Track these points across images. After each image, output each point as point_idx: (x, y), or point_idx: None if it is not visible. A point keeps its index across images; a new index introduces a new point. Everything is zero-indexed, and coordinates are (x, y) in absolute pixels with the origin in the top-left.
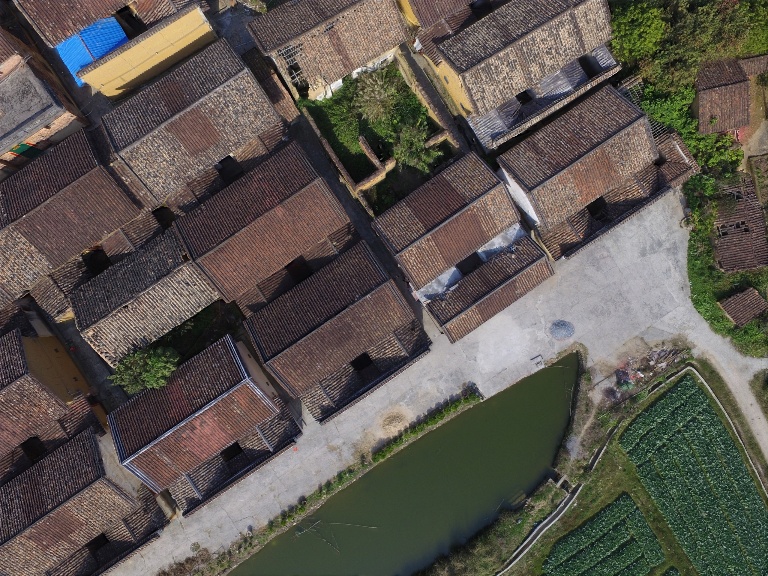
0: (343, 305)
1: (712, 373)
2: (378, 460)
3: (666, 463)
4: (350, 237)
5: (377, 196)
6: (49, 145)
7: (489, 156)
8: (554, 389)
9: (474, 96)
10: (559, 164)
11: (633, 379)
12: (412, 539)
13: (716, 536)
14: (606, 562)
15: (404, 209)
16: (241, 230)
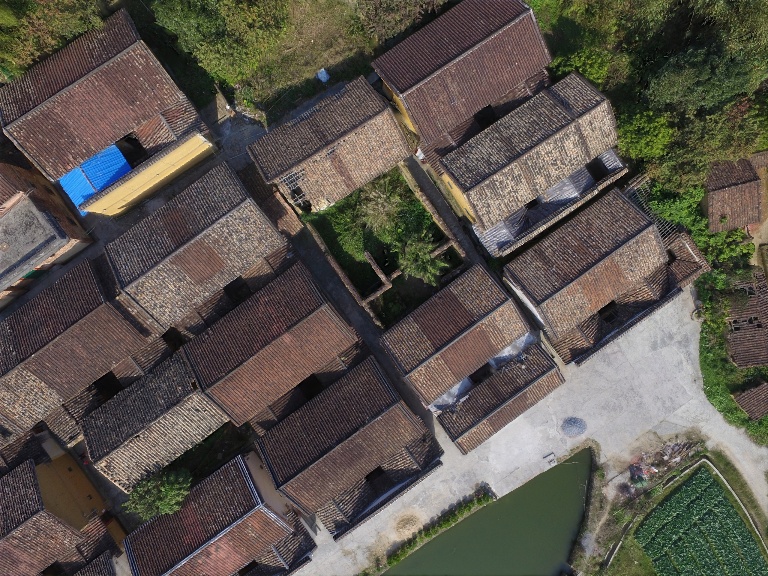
0: (354, 427)
1: (727, 465)
2: (393, 564)
3: (682, 557)
4: (358, 351)
5: (384, 301)
6: (54, 264)
7: (495, 258)
8: (567, 485)
9: (479, 211)
10: (567, 275)
11: (647, 474)
12: None
13: None
14: None
15: (412, 325)
16: (249, 359)
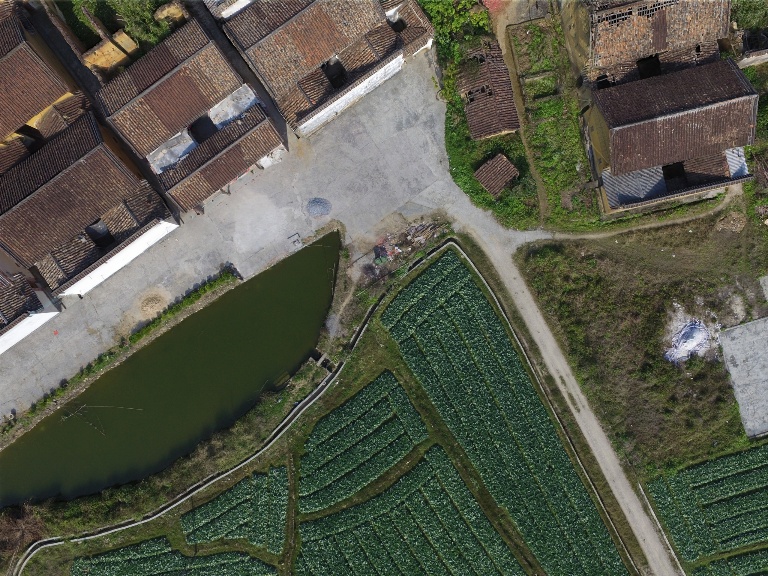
0: (59, 171)
1: (473, 247)
2: (135, 341)
3: (427, 339)
4: (83, 111)
5: None
6: None
7: None
8: (316, 269)
9: None
10: (275, 24)
11: (392, 255)
12: (178, 422)
13: (481, 412)
14: (368, 439)
15: (125, 77)
16: None
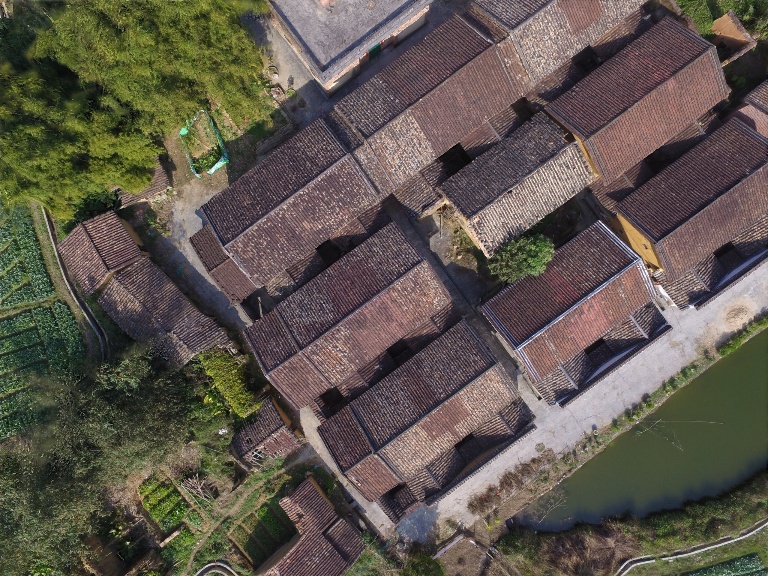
0: (733, 180)
1: None
2: (727, 353)
3: None
4: (713, 118)
5: None
6: (387, 45)
7: None
8: None
9: None
10: None
11: None
12: (756, 436)
13: None
14: None
15: None
16: (634, 105)
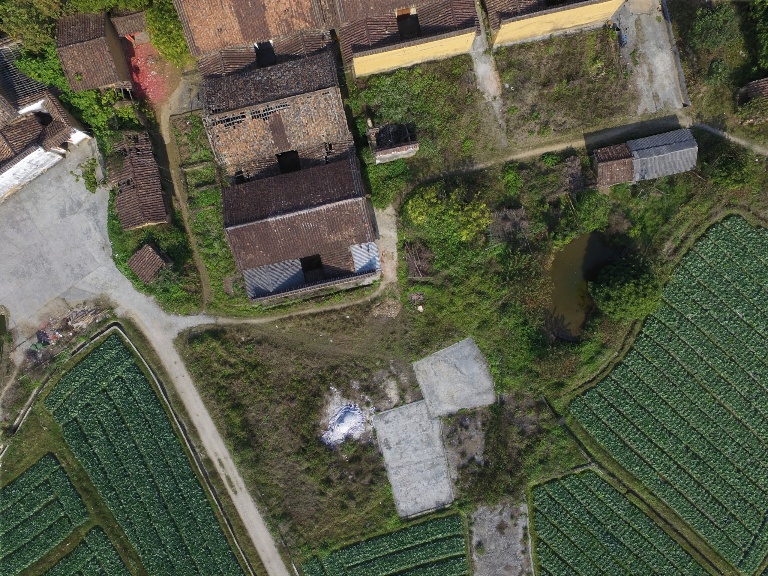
0: None
1: (134, 332)
2: None
3: (87, 422)
4: None
5: None
6: None
7: None
8: None
9: None
10: None
11: (54, 340)
12: None
13: (141, 494)
14: (27, 522)
15: None
16: None
